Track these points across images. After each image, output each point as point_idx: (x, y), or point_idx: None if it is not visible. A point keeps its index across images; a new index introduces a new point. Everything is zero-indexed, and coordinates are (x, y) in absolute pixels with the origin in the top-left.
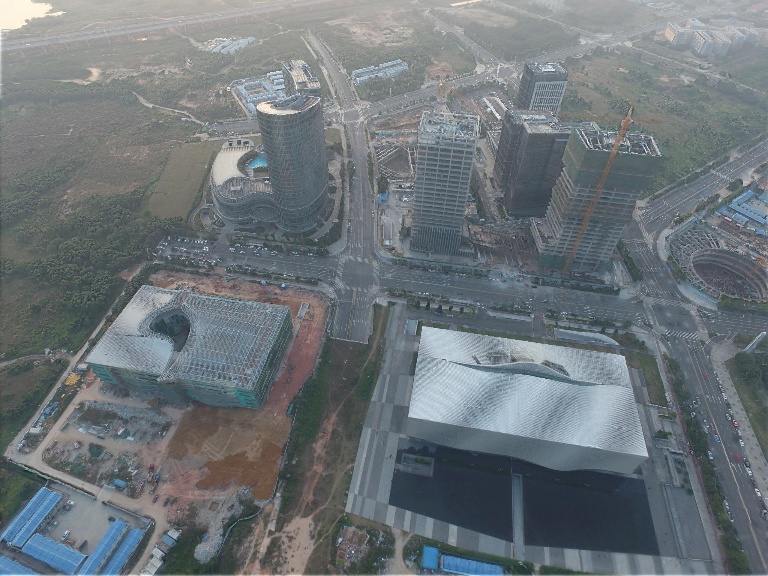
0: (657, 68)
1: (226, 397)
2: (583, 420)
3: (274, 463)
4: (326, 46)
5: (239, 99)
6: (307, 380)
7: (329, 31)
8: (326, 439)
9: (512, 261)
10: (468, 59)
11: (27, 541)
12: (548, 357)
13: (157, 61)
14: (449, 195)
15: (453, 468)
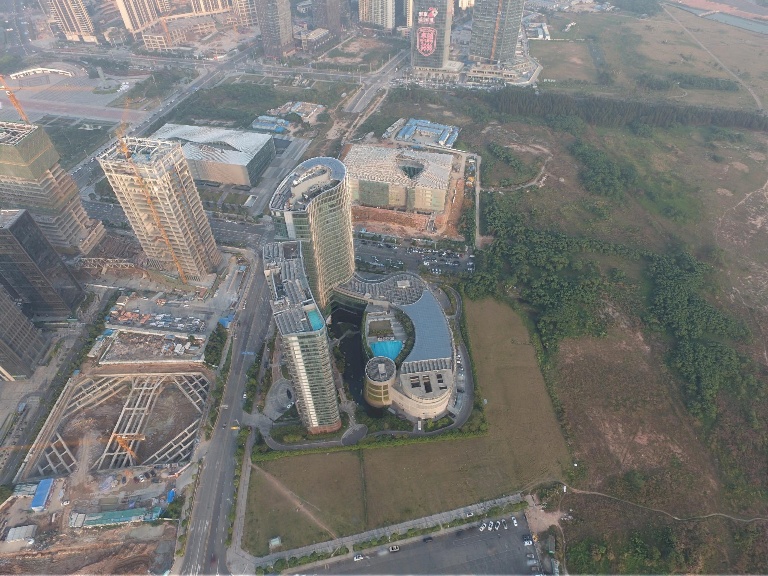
0: None
1: None
2: (185, 130)
3: (345, 152)
4: None
5: None
6: None
7: None
8: None
9: None
10: None
11: None
12: None
13: None
14: None
15: None
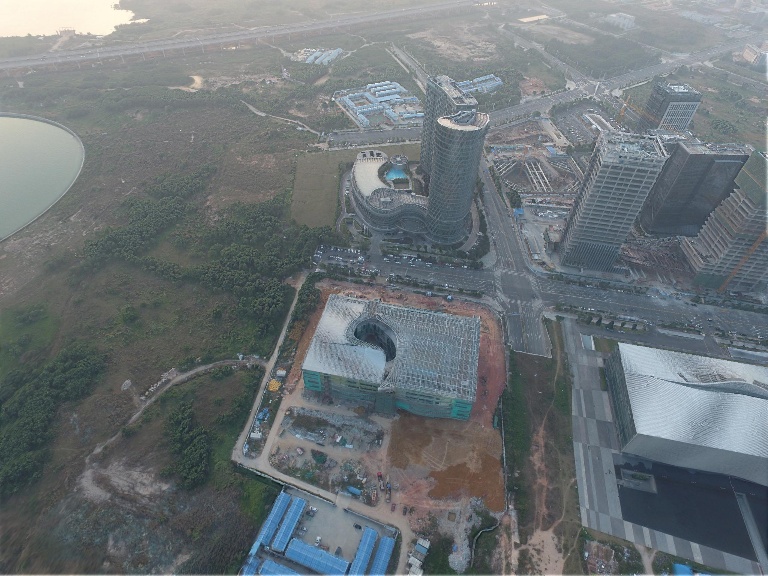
0: (745, 89)
1: (439, 408)
2: None
3: (497, 475)
4: (414, 59)
5: (346, 110)
6: (503, 392)
7: (413, 44)
8: (541, 452)
9: (665, 279)
10: (557, 75)
11: (288, 546)
12: (755, 377)
13: (255, 70)
14: (619, 213)
15: (675, 485)
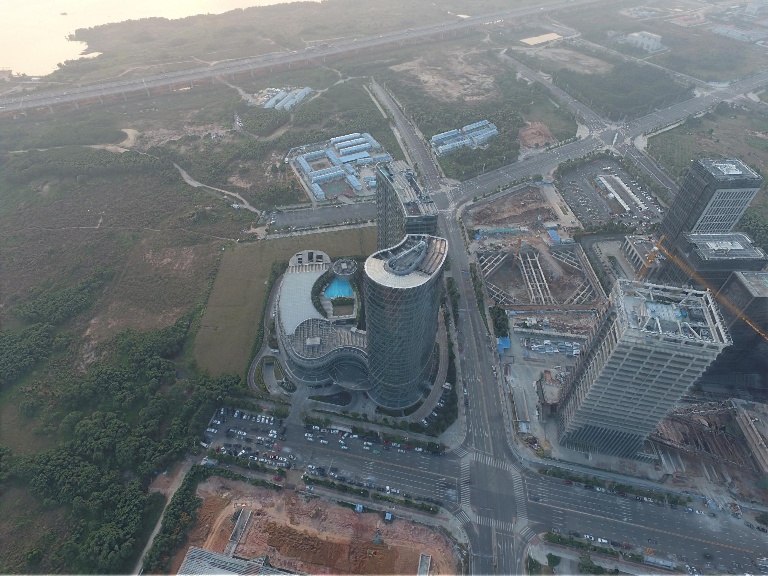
0: None
1: None
2: None
3: None
4: (395, 99)
5: (300, 175)
6: None
7: (396, 79)
8: None
9: (714, 473)
10: (566, 118)
11: None
12: None
13: (202, 120)
14: (646, 400)
15: None
